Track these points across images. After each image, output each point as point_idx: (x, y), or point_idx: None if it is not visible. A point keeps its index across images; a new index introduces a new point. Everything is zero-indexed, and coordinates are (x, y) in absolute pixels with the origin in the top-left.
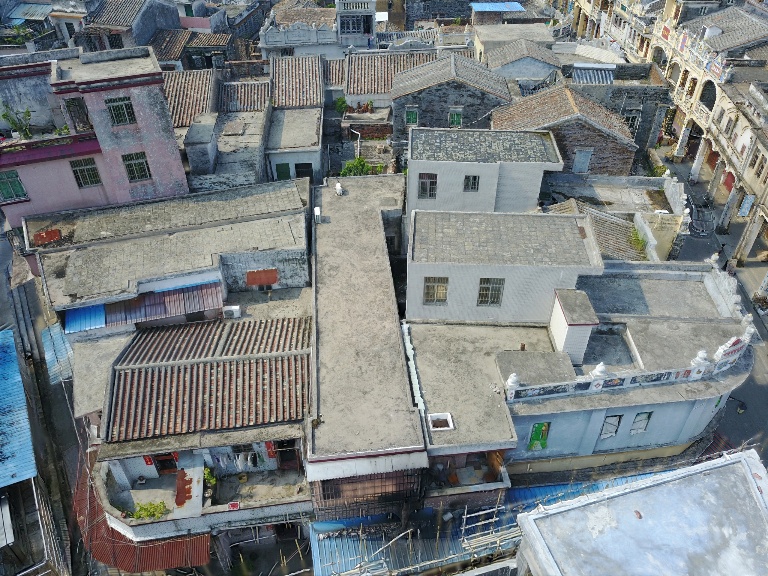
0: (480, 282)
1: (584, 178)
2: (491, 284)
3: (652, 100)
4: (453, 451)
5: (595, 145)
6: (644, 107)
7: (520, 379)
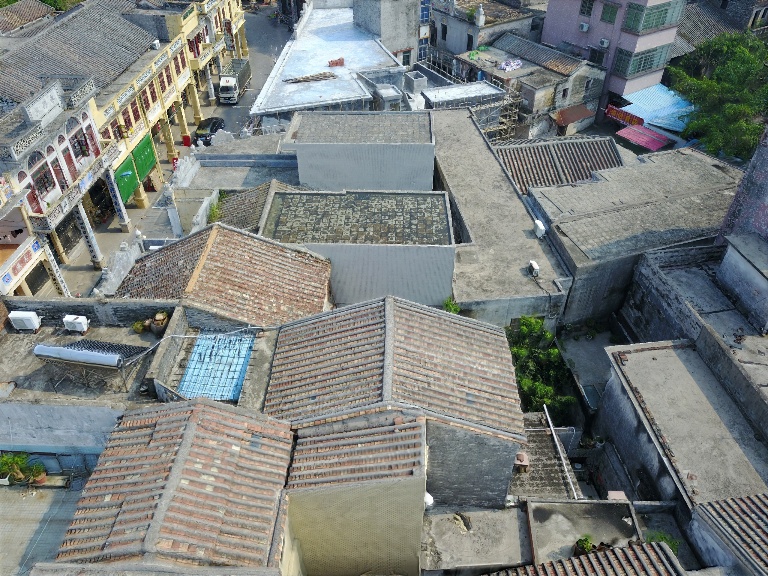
0: None
1: None
2: None
3: None
4: None
5: None
6: None
7: None
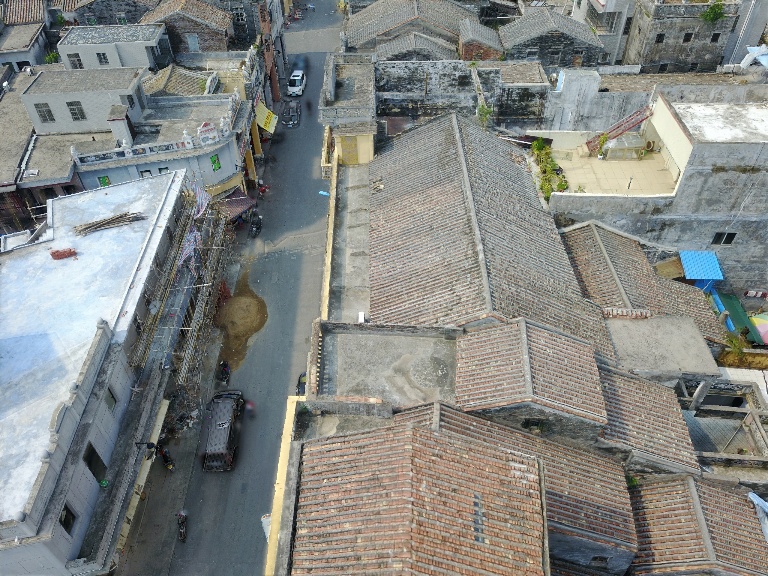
0: (67, 105)
1: (184, 52)
2: (74, 106)
3: (247, 1)
4: (33, 185)
5: (197, 31)
6: (244, 6)
7: (82, 152)
